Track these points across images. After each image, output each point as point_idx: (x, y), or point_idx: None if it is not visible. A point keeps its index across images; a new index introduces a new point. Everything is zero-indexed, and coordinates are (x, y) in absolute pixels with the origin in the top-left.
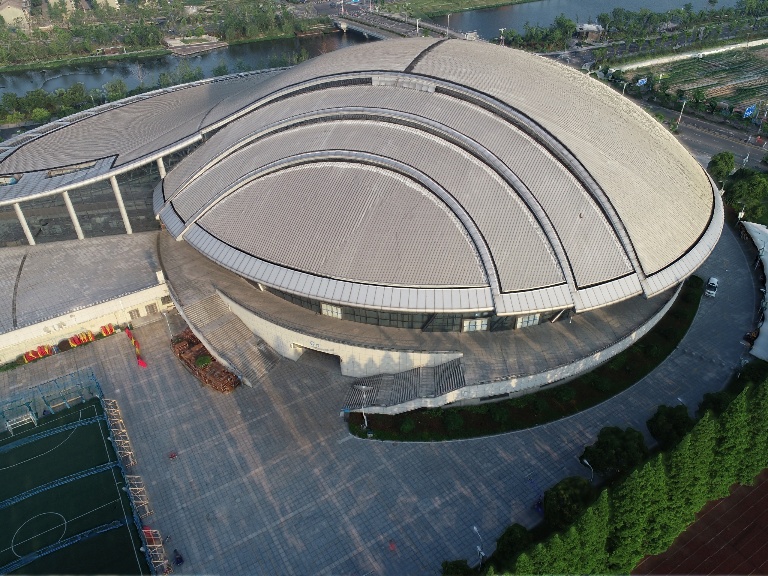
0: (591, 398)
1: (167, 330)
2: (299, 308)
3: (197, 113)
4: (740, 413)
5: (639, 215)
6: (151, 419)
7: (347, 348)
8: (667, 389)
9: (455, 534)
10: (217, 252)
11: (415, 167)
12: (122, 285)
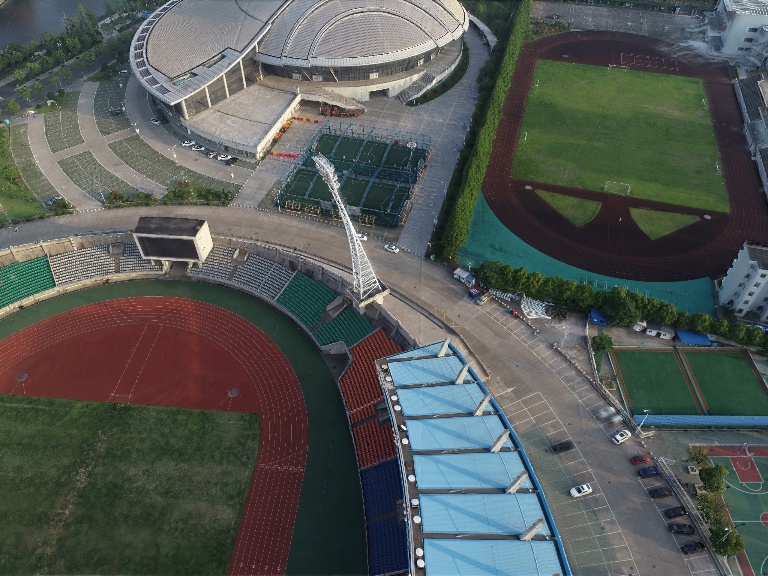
0: (462, 73)
1: (310, 113)
2: (359, 81)
3: (238, 19)
4: (511, 44)
5: (450, 6)
6: (350, 130)
7: (392, 83)
8: (477, 64)
9: (463, 110)
10: (335, 63)
11: (384, 8)
12: (283, 101)
